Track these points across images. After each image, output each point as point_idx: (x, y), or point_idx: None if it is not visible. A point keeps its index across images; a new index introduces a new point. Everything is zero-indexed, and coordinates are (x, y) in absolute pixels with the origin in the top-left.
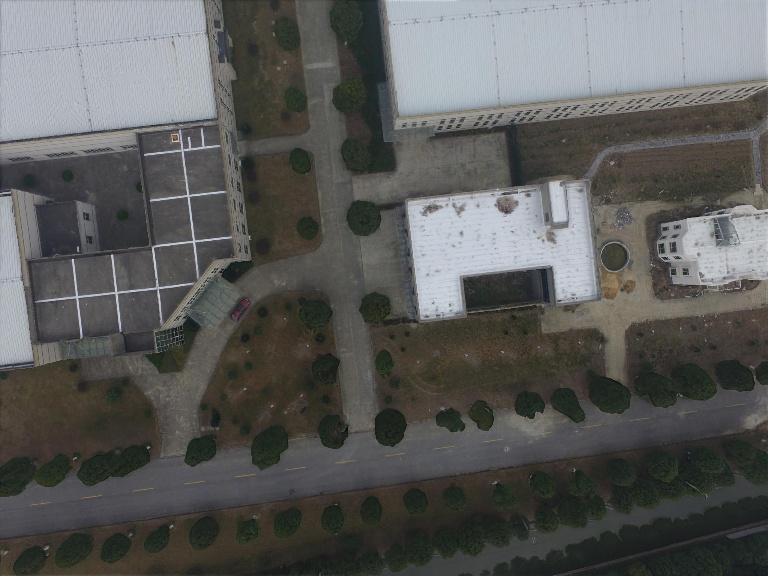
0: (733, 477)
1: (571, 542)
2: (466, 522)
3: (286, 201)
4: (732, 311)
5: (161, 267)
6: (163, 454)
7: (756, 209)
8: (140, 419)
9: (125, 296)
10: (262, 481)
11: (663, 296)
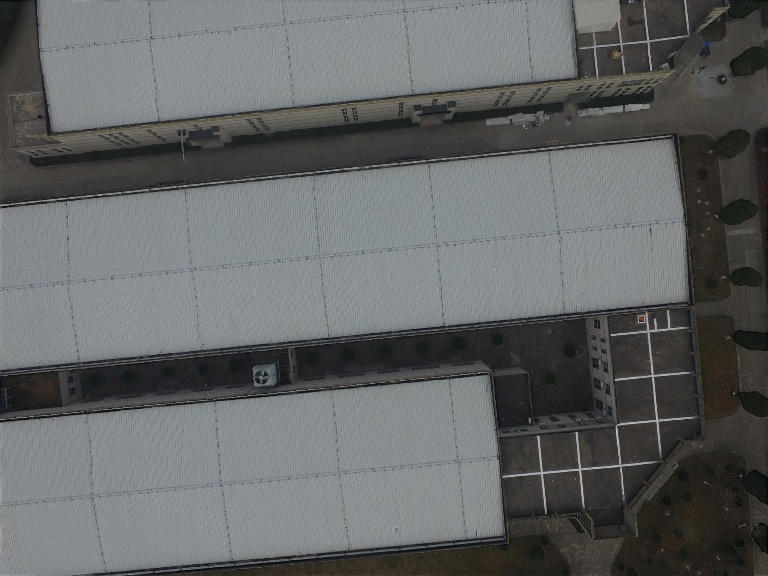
0: None
1: None
2: None
3: (708, 366)
4: None
5: (624, 445)
6: None
7: None
8: None
9: (588, 473)
10: None
11: None
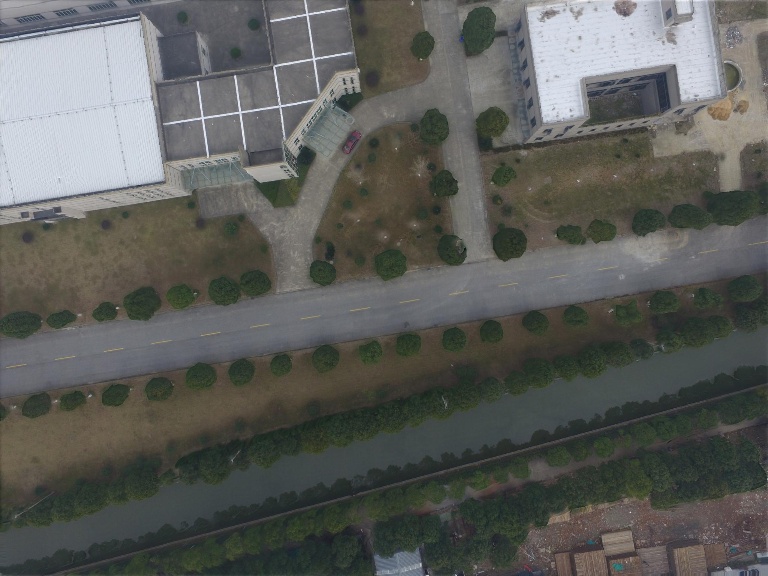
0: None
1: (684, 385)
2: (585, 348)
3: (394, 33)
4: None
5: (283, 86)
6: (279, 290)
7: None
8: (256, 255)
9: (249, 115)
10: (377, 314)
11: None
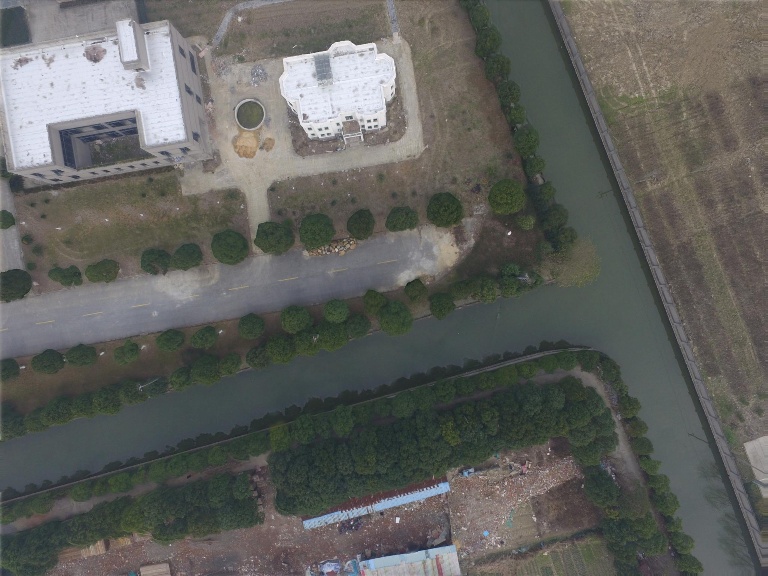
0: (359, 325)
1: (256, 417)
2: (110, 384)
3: None
4: (376, 164)
5: None
6: None
7: (354, 45)
8: None
9: None
10: None
11: (303, 152)
